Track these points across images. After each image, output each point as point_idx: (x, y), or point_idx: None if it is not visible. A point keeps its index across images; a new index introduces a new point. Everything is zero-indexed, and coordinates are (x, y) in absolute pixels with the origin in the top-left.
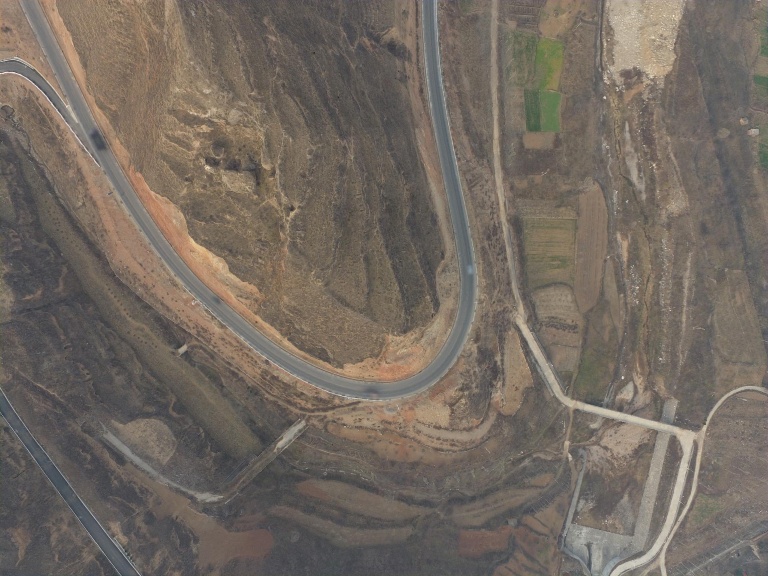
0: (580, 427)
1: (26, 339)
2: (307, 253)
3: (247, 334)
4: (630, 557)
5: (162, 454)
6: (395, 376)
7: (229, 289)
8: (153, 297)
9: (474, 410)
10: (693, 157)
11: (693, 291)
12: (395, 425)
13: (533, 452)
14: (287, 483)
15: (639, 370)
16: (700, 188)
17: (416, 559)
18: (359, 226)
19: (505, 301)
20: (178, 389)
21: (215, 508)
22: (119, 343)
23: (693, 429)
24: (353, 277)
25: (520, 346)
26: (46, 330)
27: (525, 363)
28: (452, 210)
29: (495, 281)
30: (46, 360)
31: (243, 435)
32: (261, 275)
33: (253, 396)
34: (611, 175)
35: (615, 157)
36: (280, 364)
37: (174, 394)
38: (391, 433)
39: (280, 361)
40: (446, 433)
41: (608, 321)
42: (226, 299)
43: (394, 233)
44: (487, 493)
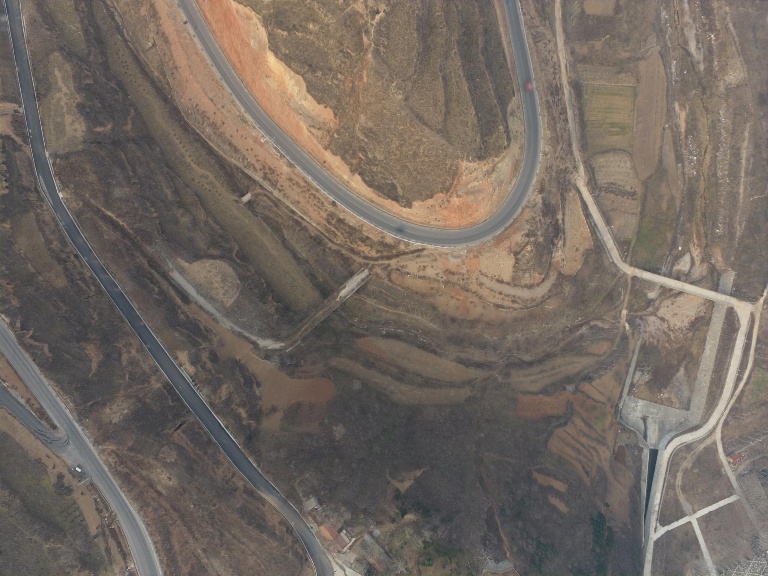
0: (638, 295)
1: (97, 168)
2: (389, 63)
3: (315, 174)
4: (686, 430)
5: (226, 296)
6: (461, 221)
7: (302, 119)
8: (221, 137)
9: (538, 262)
10: (752, 27)
11: (751, 162)
12: (458, 276)
13: (590, 319)
14: (347, 338)
15: (696, 242)
16: (758, 58)
17: (475, 419)
18: (438, 44)
19: (567, 160)
20: (241, 238)
21: (277, 355)
22: (184, 188)
23: (750, 301)
24: (431, 95)
25: (580, 208)
26: (116, 162)
27: (585, 225)
28: (517, 63)
29: (558, 136)
30: (116, 189)
31: (304, 288)
32: (338, 95)
33: (315, 248)
34: (670, 45)
35: (674, 27)
36: (347, 206)
37: (236, 243)
38: (453, 286)
39: (347, 203)
40: (508, 288)
41: (666, 190)
42: (295, 138)
43: (469, 60)
44: (544, 359)
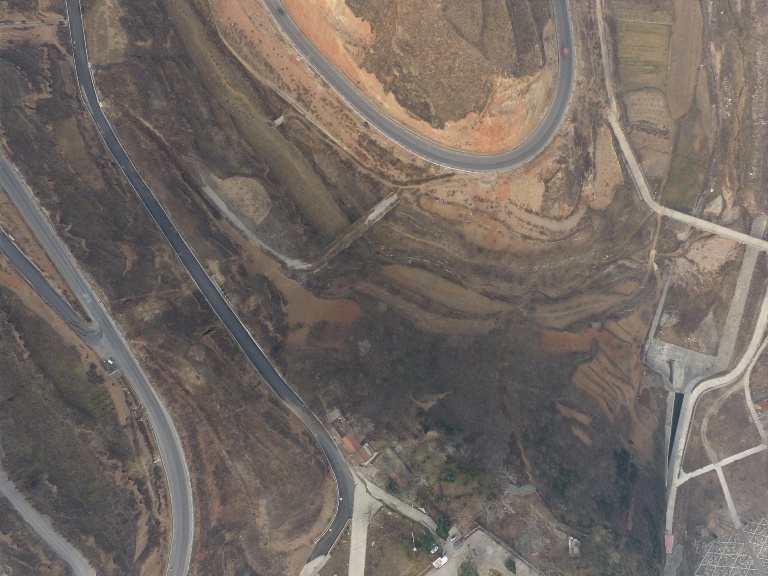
0: (668, 235)
1: (137, 79)
2: None
3: (348, 94)
4: (714, 375)
5: (257, 214)
6: (492, 146)
7: (338, 35)
8: (257, 57)
9: (568, 191)
10: None
11: None
12: (487, 203)
13: (618, 258)
14: (373, 264)
15: (728, 184)
16: None
17: (499, 350)
18: None
19: (599, 94)
20: (272, 161)
21: (304, 276)
22: (219, 108)
23: None
24: (469, 7)
25: (612, 143)
26: (155, 76)
27: (616, 160)
28: None
29: (592, 68)
30: (155, 101)
31: (332, 213)
32: (376, 7)
33: (345, 173)
34: None
35: None
36: (379, 127)
37: (268, 165)
38: (481, 215)
39: (379, 124)
40: (536, 219)
41: (699, 131)
42: (330, 57)
43: None
44: (570, 296)
